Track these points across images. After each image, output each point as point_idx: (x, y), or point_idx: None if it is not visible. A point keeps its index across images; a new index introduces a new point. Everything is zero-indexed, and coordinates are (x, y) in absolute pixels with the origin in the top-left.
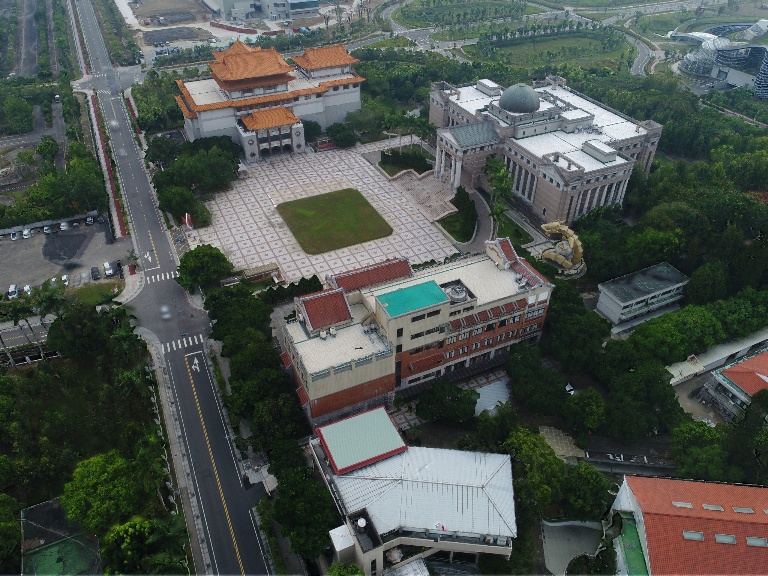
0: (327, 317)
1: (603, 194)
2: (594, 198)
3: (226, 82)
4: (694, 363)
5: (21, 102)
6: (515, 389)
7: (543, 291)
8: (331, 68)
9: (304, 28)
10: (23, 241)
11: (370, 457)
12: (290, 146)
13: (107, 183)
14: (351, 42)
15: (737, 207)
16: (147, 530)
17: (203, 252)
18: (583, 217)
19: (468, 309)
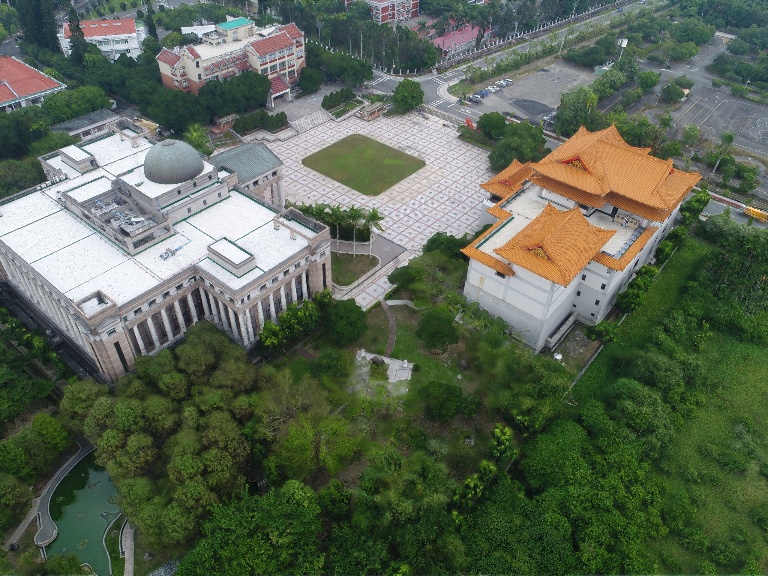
0: None
1: None
2: None
3: None
4: None
5: None
6: None
7: None
8: None
9: None
10: None
11: None
12: None
13: None
14: None
15: None
16: (301, 3)
17: None
18: None
19: None
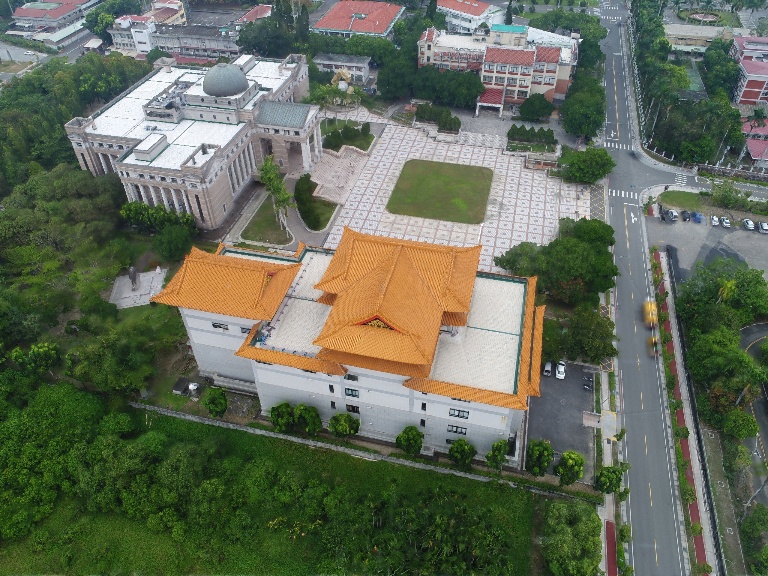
0: None
1: None
2: None
3: None
4: None
5: None
6: None
7: None
8: None
9: None
10: None
11: (559, 42)
12: None
13: (681, 363)
14: None
15: None
16: None
17: (591, 150)
18: None
19: None
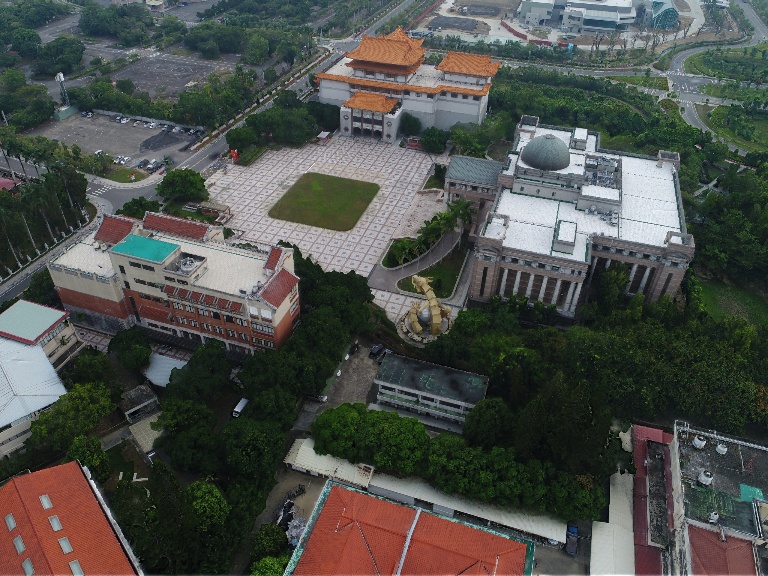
0: (110, 235)
1: (542, 286)
2: (528, 285)
3: (355, 60)
4: (363, 474)
5: (259, 41)
6: (172, 370)
7: (264, 308)
8: (466, 75)
9: (572, 44)
10: (148, 129)
11: (8, 332)
12: (381, 133)
13: None
14: (602, 69)
15: (593, 359)
16: None
17: (181, 173)
18: (495, 297)
19: (183, 282)
